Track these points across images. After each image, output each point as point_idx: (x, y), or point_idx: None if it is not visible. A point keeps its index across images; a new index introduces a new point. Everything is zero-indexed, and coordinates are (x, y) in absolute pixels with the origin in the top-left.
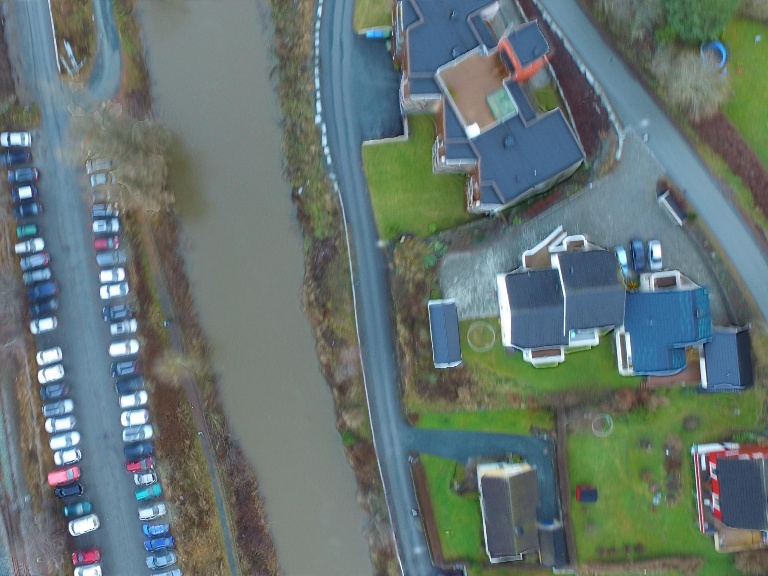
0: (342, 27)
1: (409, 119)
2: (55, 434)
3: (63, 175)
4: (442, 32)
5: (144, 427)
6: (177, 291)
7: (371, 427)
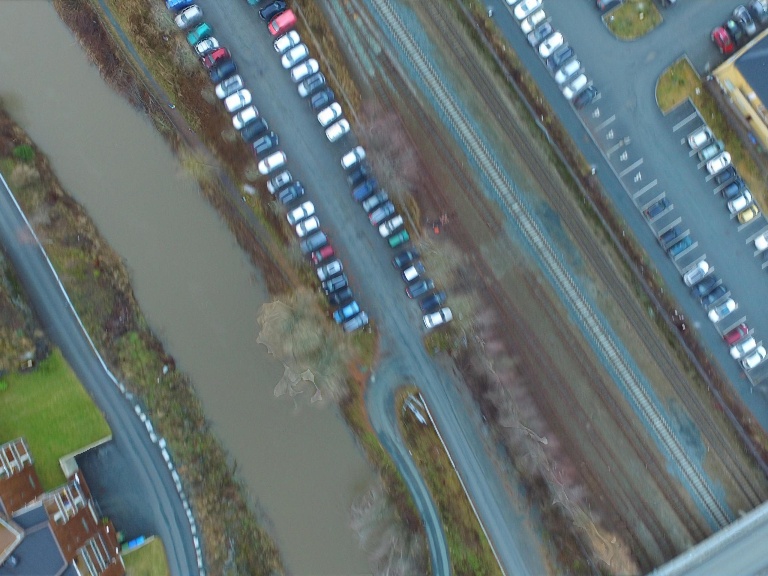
0: (172, 536)
1: (65, 478)
2: (306, 59)
3: (388, 301)
4: (35, 574)
5: (226, 95)
6: (245, 234)
7: (0, 172)
